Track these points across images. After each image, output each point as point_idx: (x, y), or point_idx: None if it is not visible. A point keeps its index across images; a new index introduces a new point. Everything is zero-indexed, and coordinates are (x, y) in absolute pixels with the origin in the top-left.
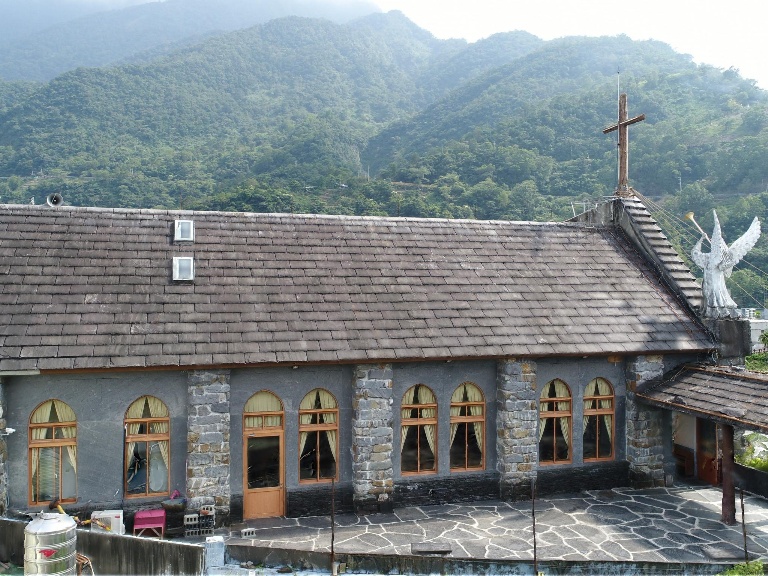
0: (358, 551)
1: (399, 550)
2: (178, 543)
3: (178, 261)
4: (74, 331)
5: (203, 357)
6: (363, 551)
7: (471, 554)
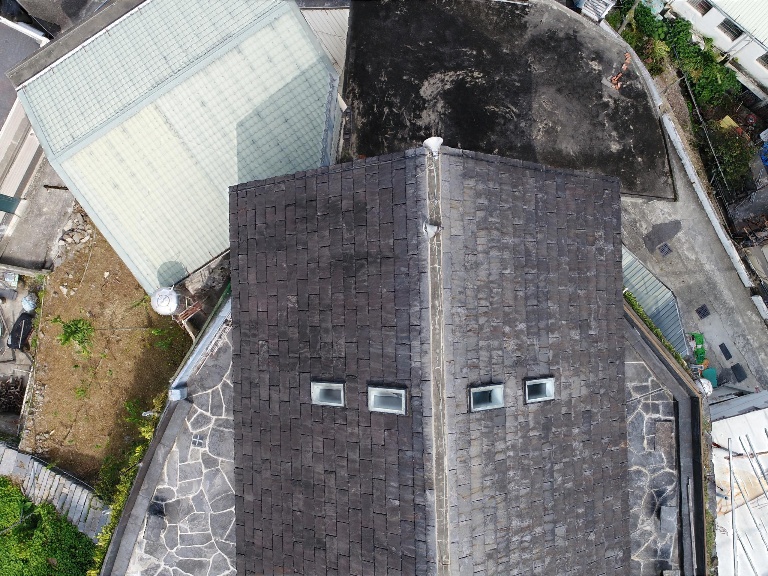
0: (208, 487)
1: (202, 514)
2: (181, 372)
3: (340, 389)
4: (260, 292)
5: (239, 403)
6: (207, 490)
7: (183, 560)
